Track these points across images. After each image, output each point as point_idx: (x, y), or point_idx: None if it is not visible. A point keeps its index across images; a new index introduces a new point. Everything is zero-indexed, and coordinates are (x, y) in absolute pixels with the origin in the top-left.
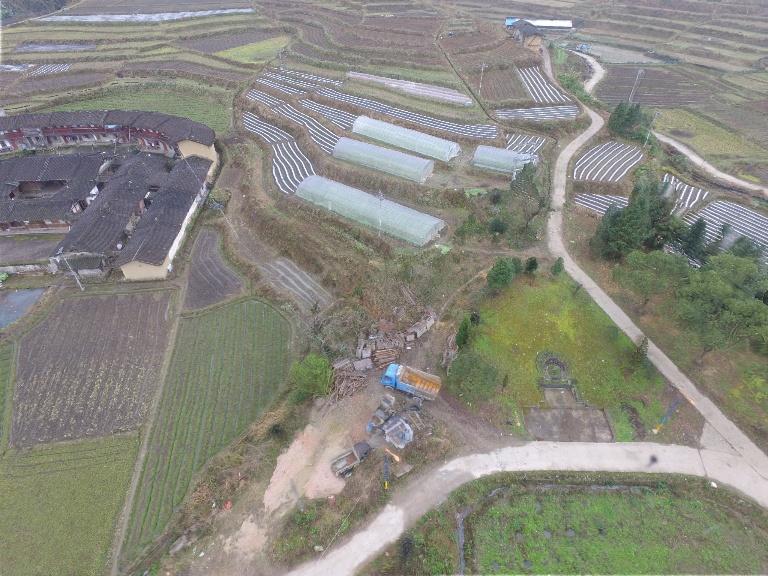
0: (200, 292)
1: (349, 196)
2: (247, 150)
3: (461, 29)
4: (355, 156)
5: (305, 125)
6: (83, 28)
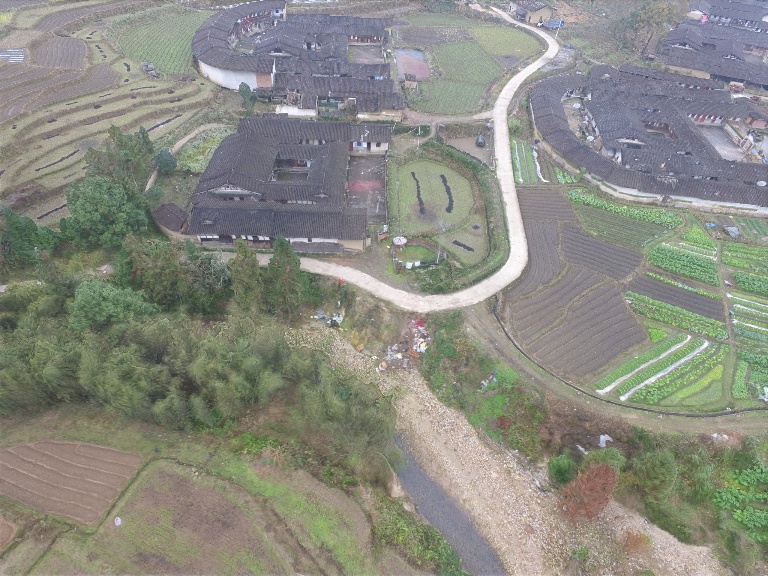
0: None
1: None
2: None
3: None
4: None
5: None
6: None
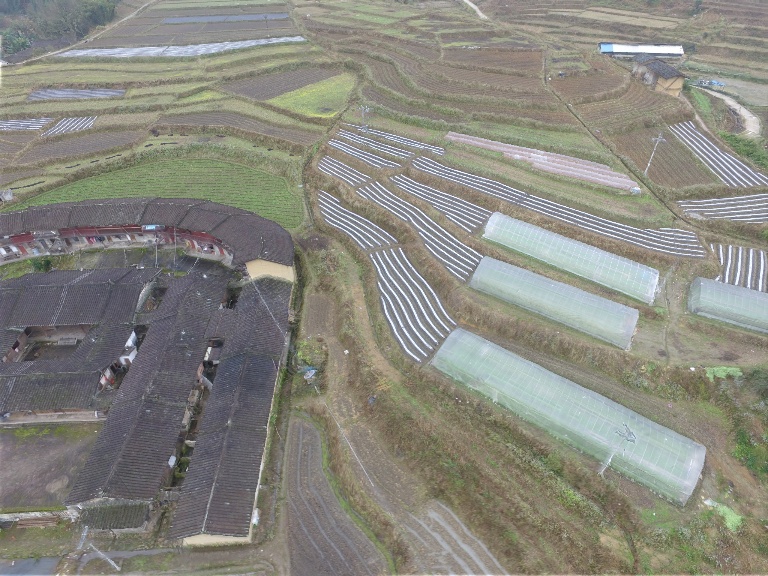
0: None
1: (528, 384)
2: (336, 262)
3: (571, 66)
4: (510, 293)
5: (411, 221)
6: (109, 66)
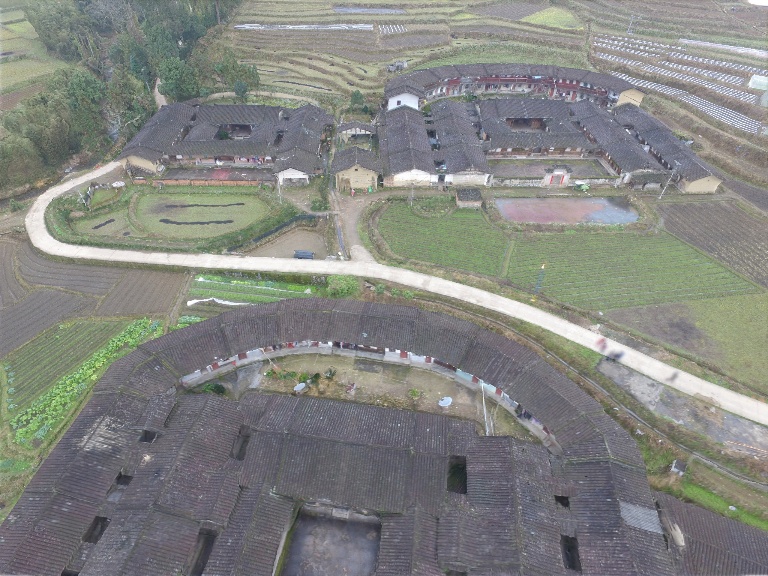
0: (761, 202)
1: None
2: None
3: (736, 5)
4: None
5: (694, 82)
6: None
